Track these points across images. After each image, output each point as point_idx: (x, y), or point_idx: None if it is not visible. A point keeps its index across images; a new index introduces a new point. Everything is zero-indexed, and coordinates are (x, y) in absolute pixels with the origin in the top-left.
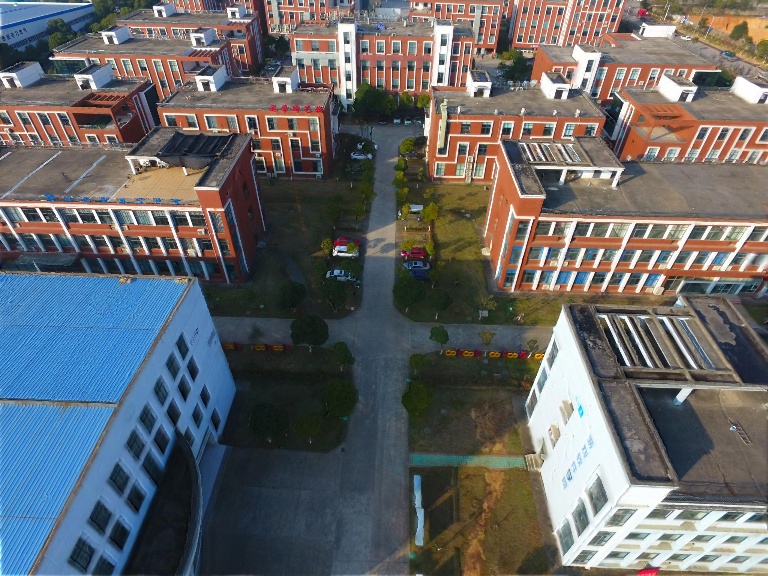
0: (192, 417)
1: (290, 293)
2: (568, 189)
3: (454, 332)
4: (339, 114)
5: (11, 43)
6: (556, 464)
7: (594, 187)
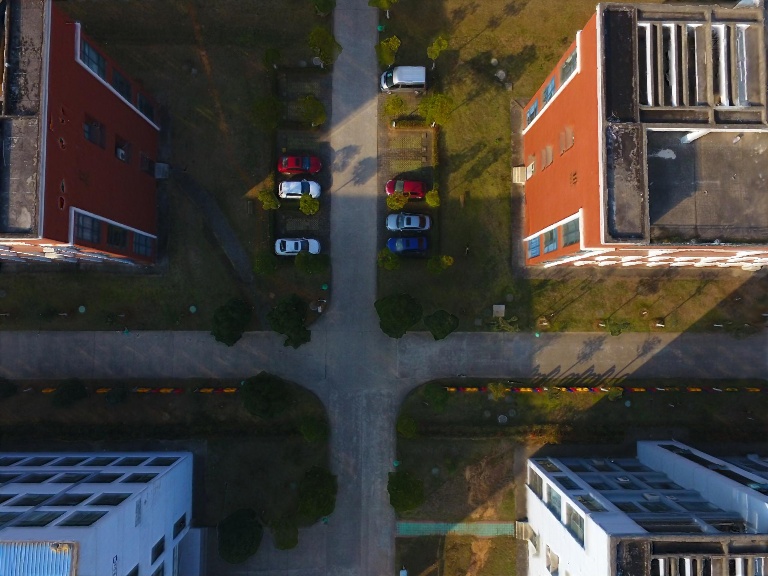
0: None
1: (227, 332)
2: (694, 155)
3: (456, 347)
4: None
5: None
6: None
7: (743, 147)
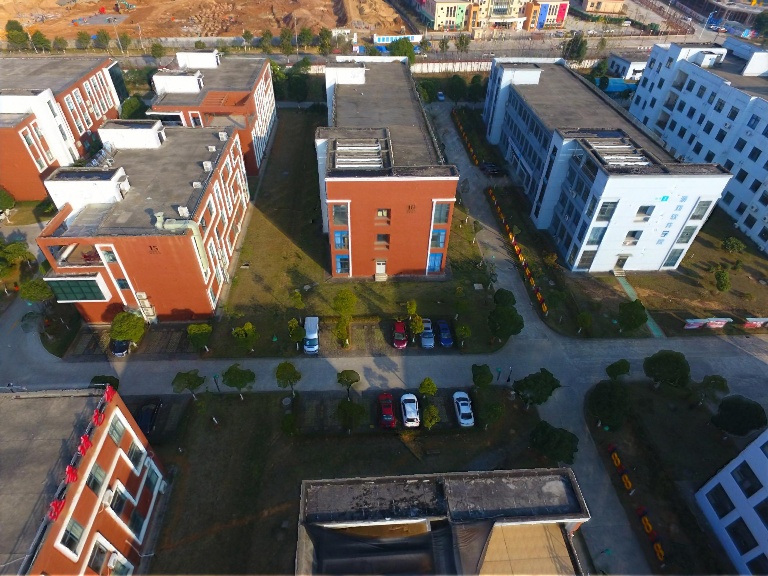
0: None
1: (568, 432)
2: None
3: None
4: None
5: None
6: (645, 246)
7: None
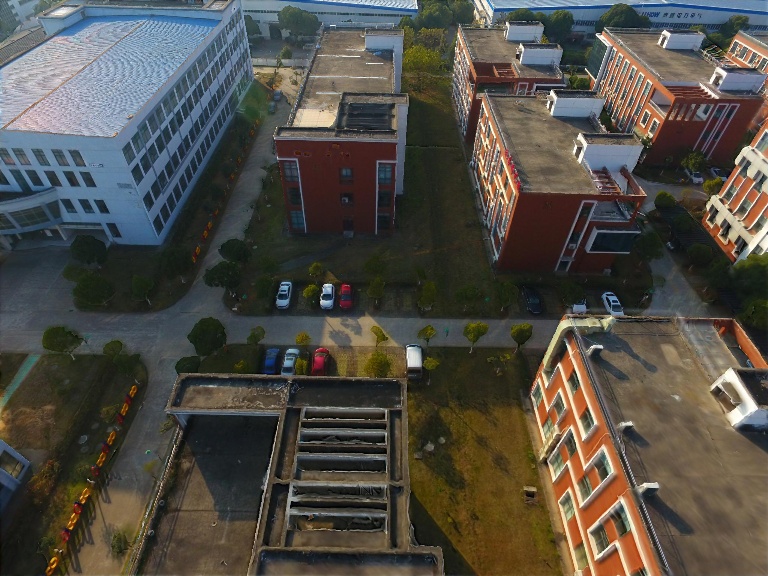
0: (78, 200)
1: (226, 244)
2: None
3: None
4: (698, 260)
5: (670, 22)
6: None
7: None
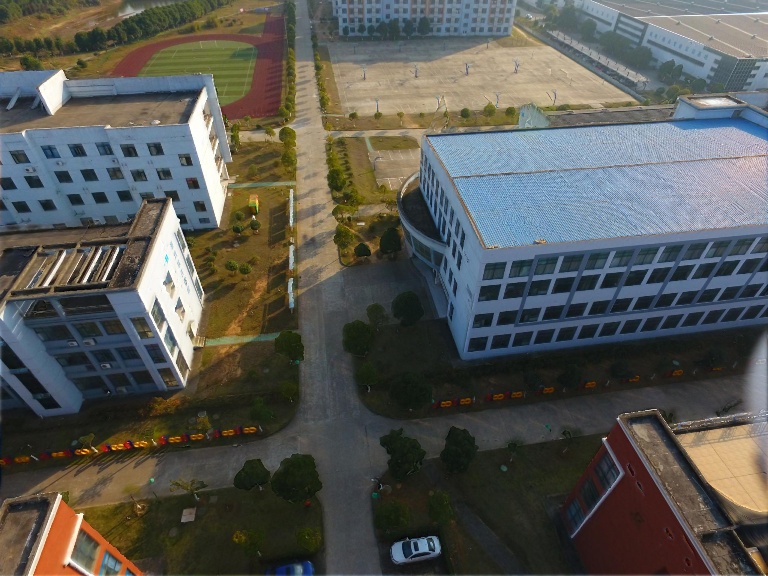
0: None
1: (456, 432)
2: None
3: None
4: None
5: None
6: None
7: None
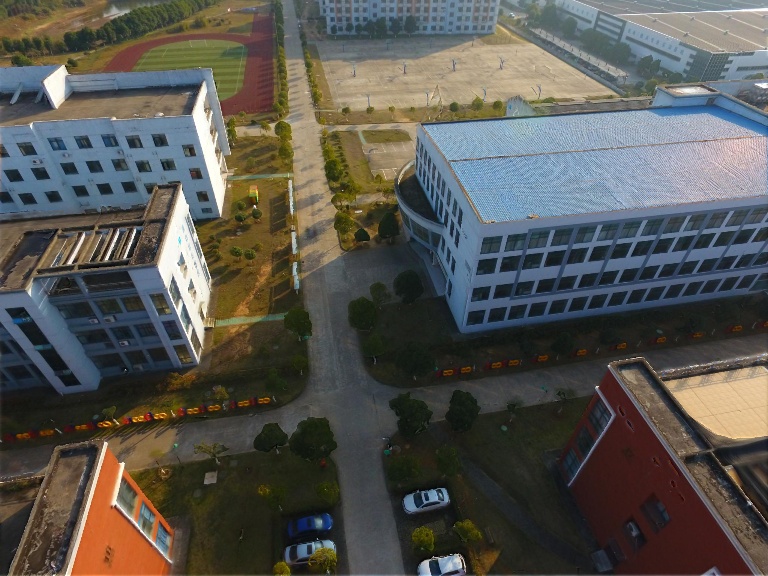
0: None
1: None
2: None
3: None
4: None
5: None
6: None
7: None
